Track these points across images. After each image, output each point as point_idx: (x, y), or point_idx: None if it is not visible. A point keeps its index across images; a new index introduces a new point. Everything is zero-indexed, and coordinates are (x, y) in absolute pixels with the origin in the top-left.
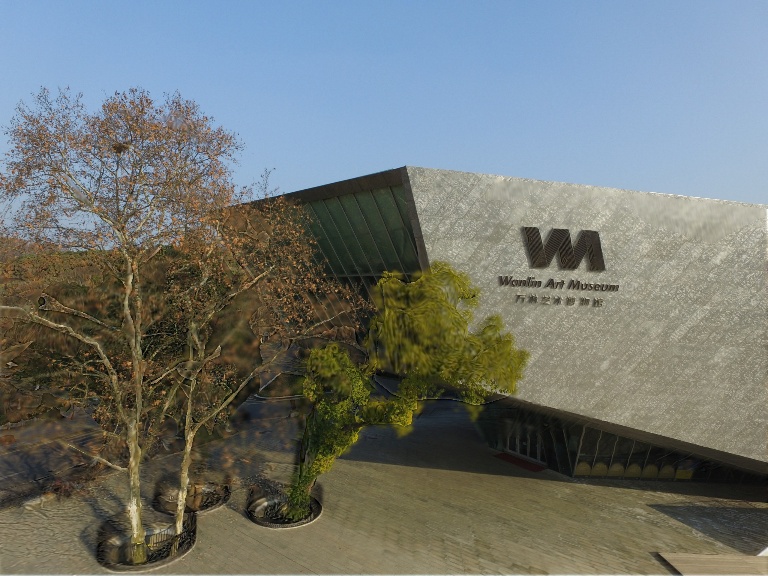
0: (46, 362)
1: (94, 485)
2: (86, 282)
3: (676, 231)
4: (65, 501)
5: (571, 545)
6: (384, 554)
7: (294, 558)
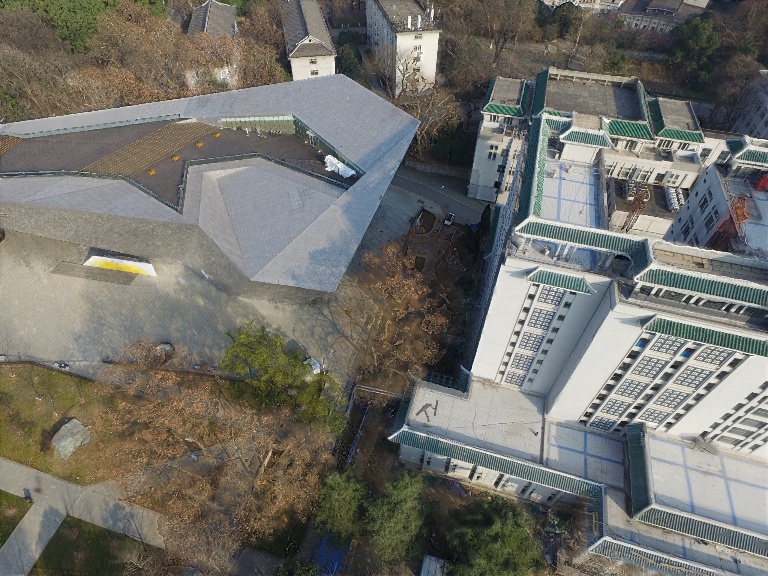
0: None
1: None
2: None
3: (7, 206)
4: None
5: (47, 257)
6: (3, 256)
7: None
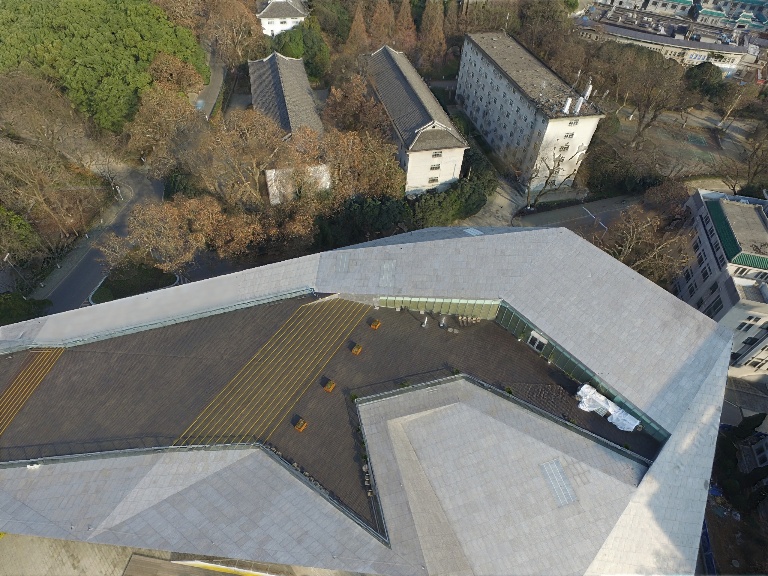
0: None
1: None
2: None
3: None
4: None
5: None
6: (29, 542)
7: None
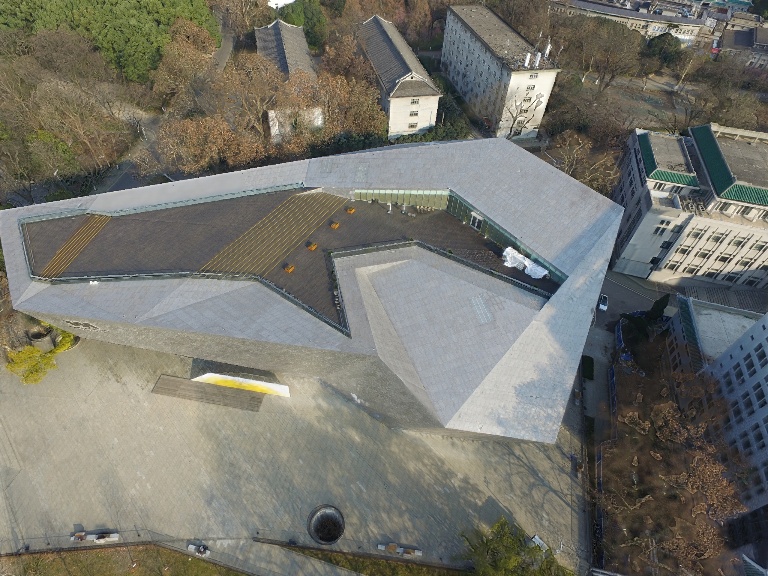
0: (6, 161)
1: (12, 319)
2: (4, 78)
3: None
4: (2, 329)
5: (141, 368)
6: (83, 366)
7: (57, 365)
